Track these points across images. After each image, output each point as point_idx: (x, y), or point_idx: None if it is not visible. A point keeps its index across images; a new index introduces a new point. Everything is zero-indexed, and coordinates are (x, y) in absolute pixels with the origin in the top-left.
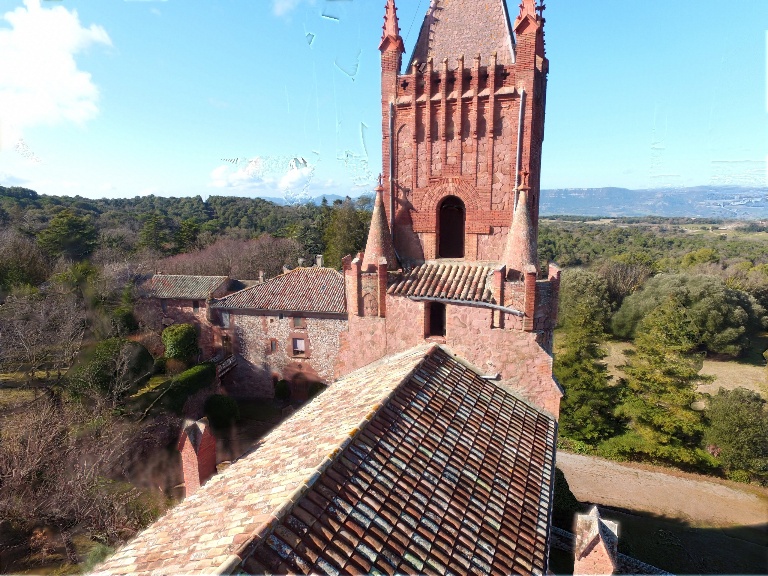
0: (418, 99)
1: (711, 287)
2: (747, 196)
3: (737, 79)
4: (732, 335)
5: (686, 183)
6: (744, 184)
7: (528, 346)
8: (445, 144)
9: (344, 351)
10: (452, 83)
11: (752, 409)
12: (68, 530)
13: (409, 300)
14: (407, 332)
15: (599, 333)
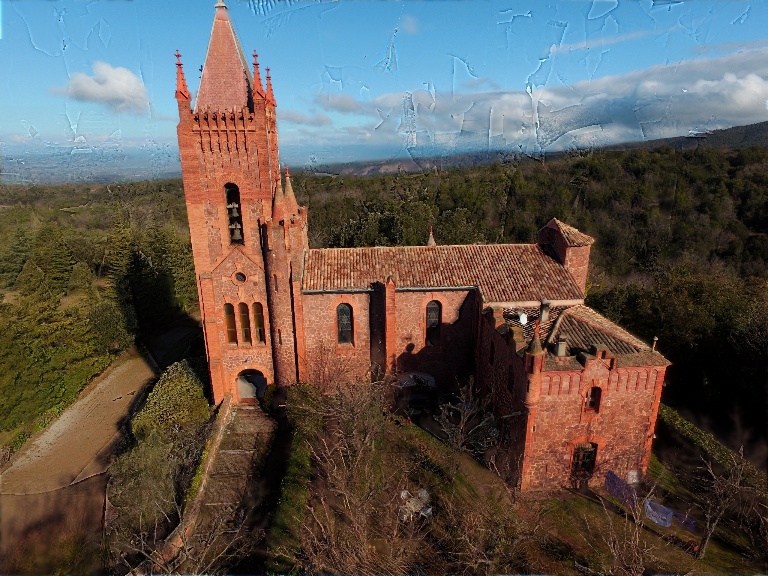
0: None
1: None
2: None
3: None
4: None
5: None
6: None
7: None
8: None
9: None
10: None
11: (114, 310)
12: None
13: None
14: None
15: (8, 312)
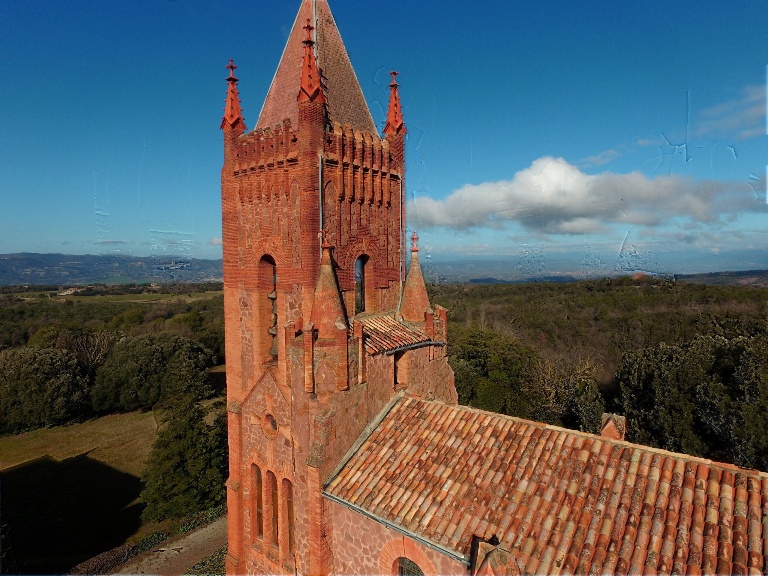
0: (344, 160)
1: (179, 340)
2: (180, 262)
3: (157, 164)
4: (204, 377)
5: (133, 249)
6: (177, 252)
7: (445, 368)
8: (360, 207)
9: (331, 442)
10: (363, 154)
11: None
12: None
13: (384, 356)
14: (383, 390)
15: (201, 393)
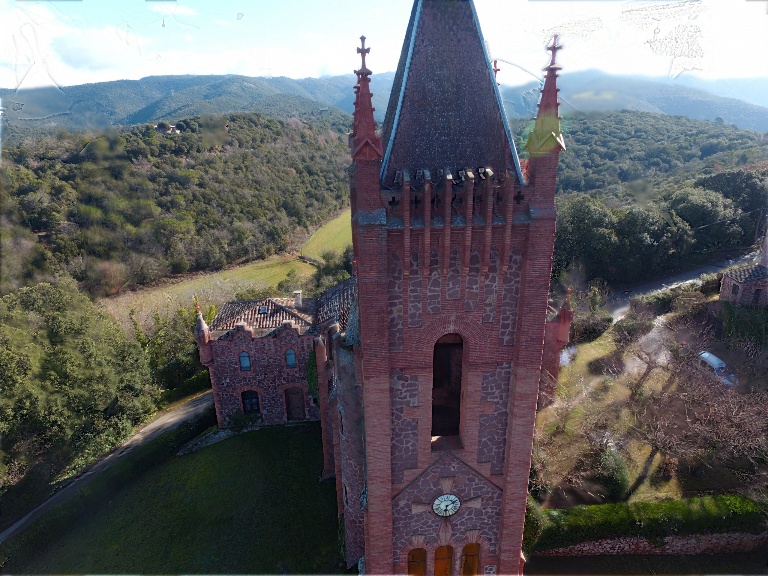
0: None
1: None
2: None
3: None
4: None
5: None
6: None
7: None
8: None
9: None
10: None
11: None
12: (695, 491)
13: None
14: None
15: None
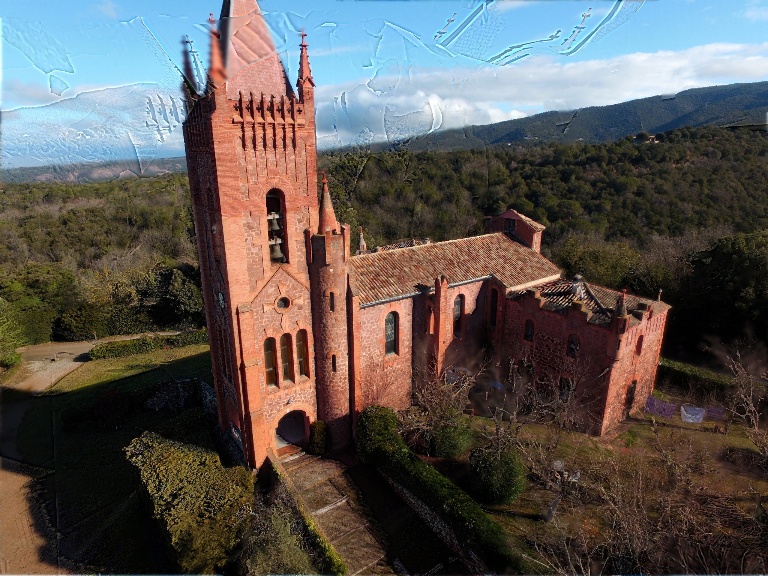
0: None
1: None
2: None
3: None
4: None
5: None
6: None
7: None
8: None
9: None
10: None
11: None
12: (581, 574)
13: None
14: None
15: None
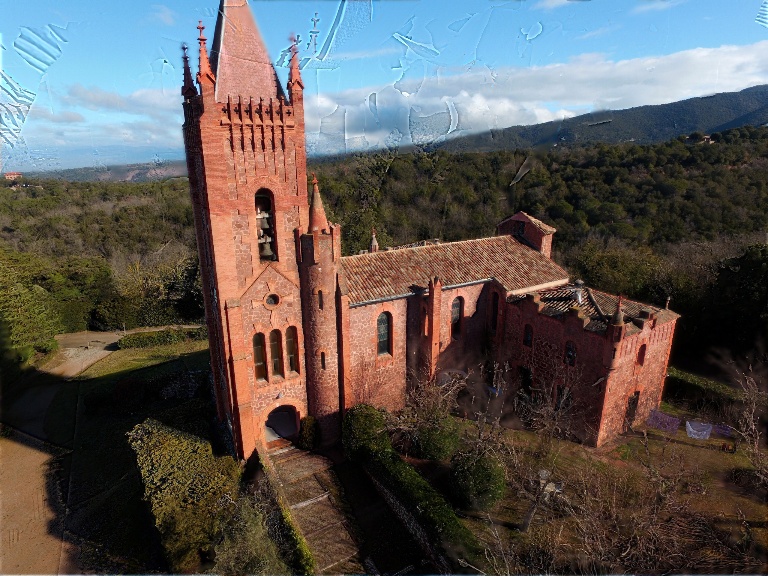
0: None
1: None
2: None
3: None
4: None
5: None
6: None
7: None
8: None
9: None
10: None
11: None
12: None
13: None
14: None
15: None
